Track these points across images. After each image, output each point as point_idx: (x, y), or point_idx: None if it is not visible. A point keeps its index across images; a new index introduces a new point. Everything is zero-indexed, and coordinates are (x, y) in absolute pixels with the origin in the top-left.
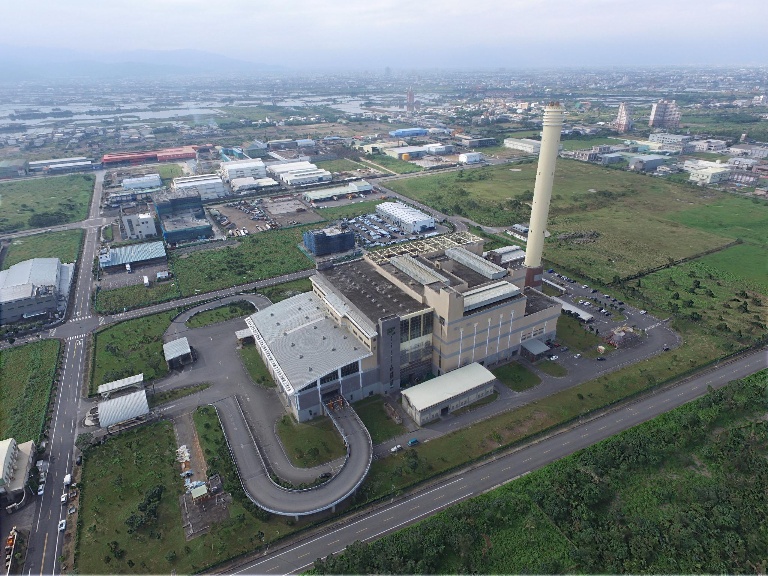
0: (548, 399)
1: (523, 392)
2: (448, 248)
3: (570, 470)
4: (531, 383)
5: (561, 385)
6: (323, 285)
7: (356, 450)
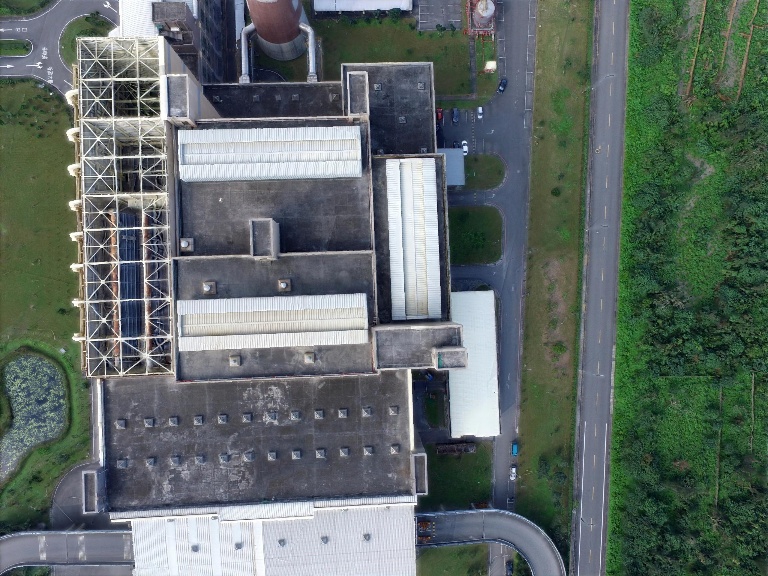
0: (533, 233)
1: (504, 253)
2: (167, 160)
3: (649, 314)
4: (495, 228)
5: (519, 192)
6: (173, 510)
7: (510, 534)
